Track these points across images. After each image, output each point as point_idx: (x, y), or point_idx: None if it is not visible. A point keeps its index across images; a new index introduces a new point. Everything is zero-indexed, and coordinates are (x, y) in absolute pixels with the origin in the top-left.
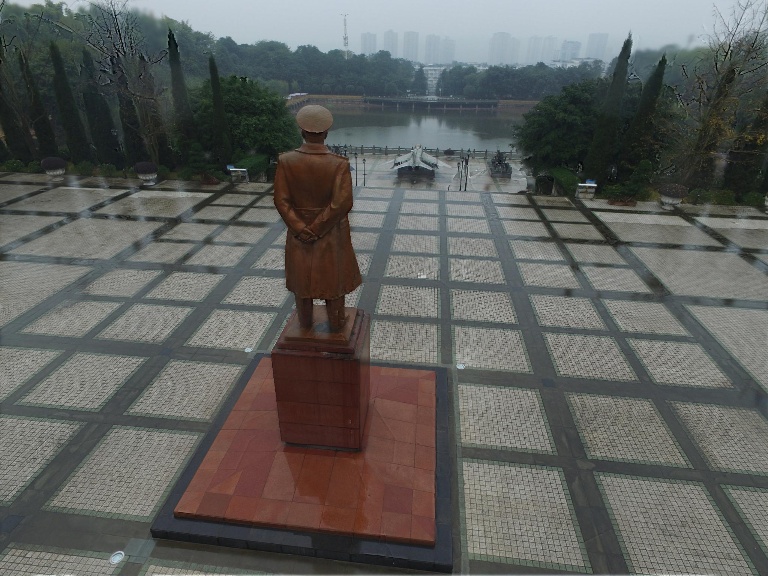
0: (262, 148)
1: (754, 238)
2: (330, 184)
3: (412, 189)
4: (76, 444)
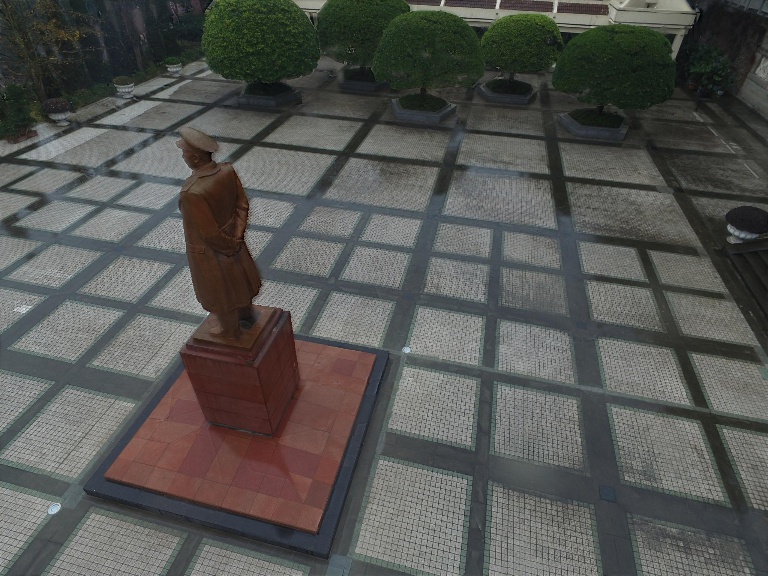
0: None
1: (155, 120)
2: (236, 190)
3: None
4: None
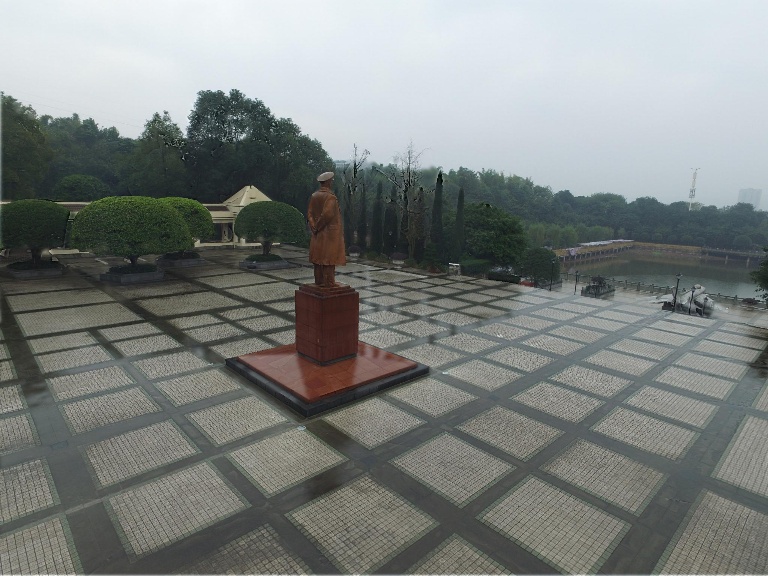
0: (486, 255)
1: None
2: (323, 205)
3: (591, 298)
4: (238, 337)
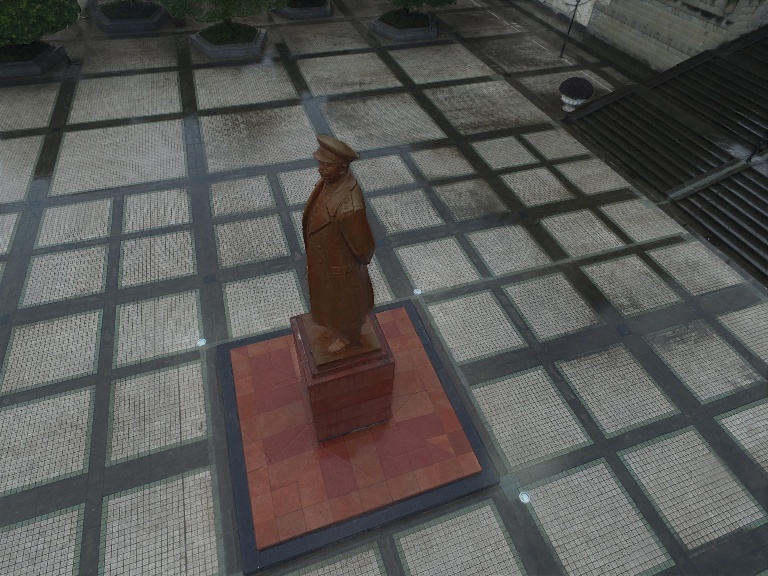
0: None
1: None
2: None
3: None
4: None
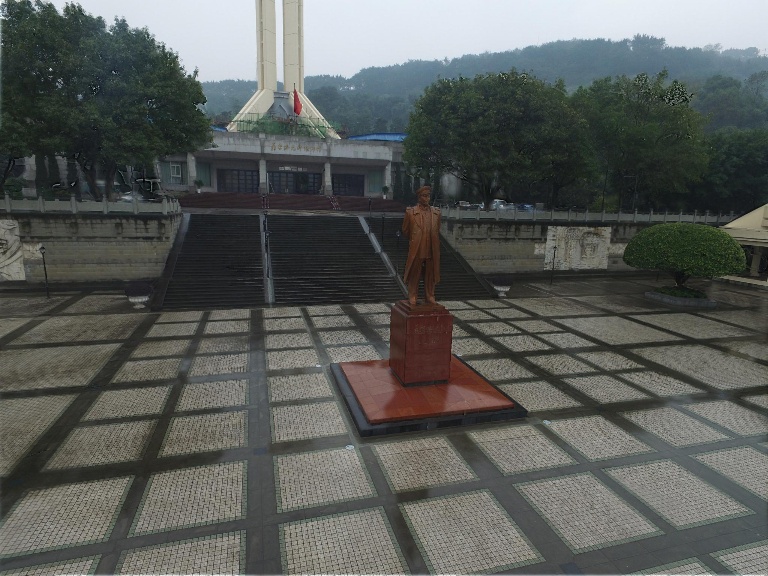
0: None
1: None
2: None
3: None
4: None
